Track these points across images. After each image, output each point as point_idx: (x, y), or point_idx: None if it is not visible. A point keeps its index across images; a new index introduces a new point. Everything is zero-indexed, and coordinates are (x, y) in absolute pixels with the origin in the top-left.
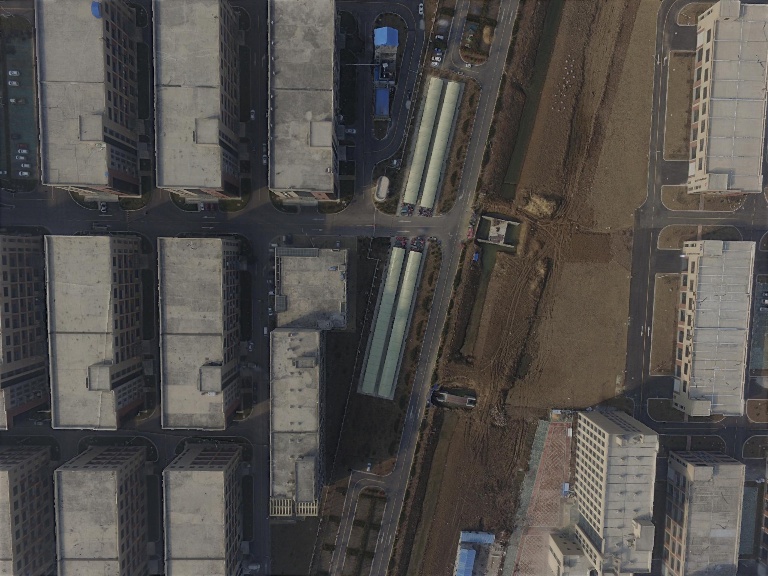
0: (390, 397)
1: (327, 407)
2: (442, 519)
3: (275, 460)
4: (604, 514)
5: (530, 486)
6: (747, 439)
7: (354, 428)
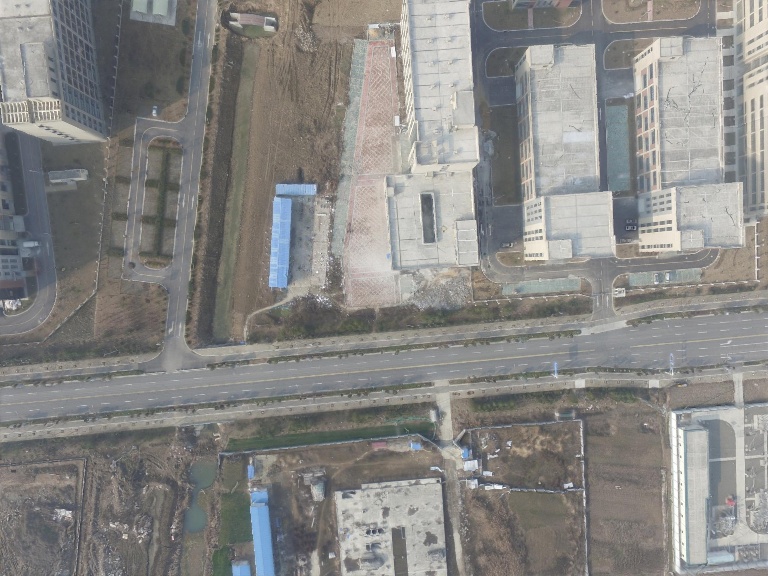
0: (171, 22)
1: (97, 40)
2: (254, 175)
3: (3, 56)
4: (413, 88)
5: (353, 124)
6: (607, 45)
7: (131, 63)
